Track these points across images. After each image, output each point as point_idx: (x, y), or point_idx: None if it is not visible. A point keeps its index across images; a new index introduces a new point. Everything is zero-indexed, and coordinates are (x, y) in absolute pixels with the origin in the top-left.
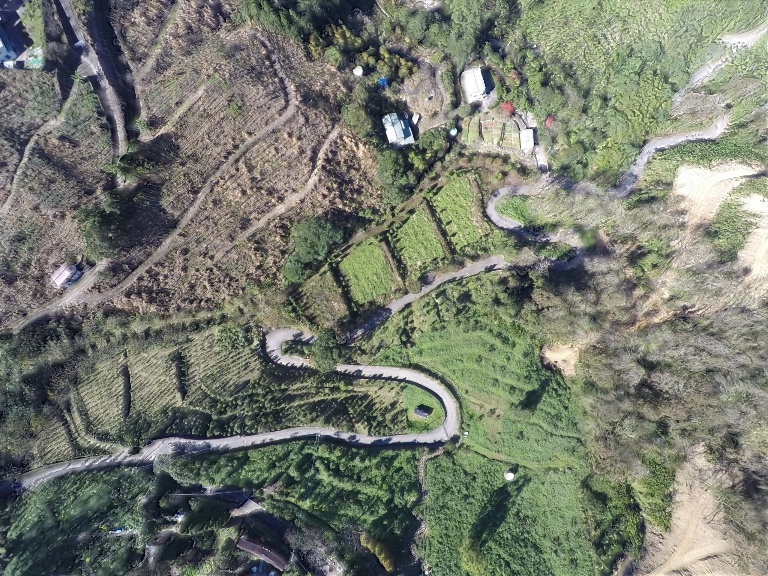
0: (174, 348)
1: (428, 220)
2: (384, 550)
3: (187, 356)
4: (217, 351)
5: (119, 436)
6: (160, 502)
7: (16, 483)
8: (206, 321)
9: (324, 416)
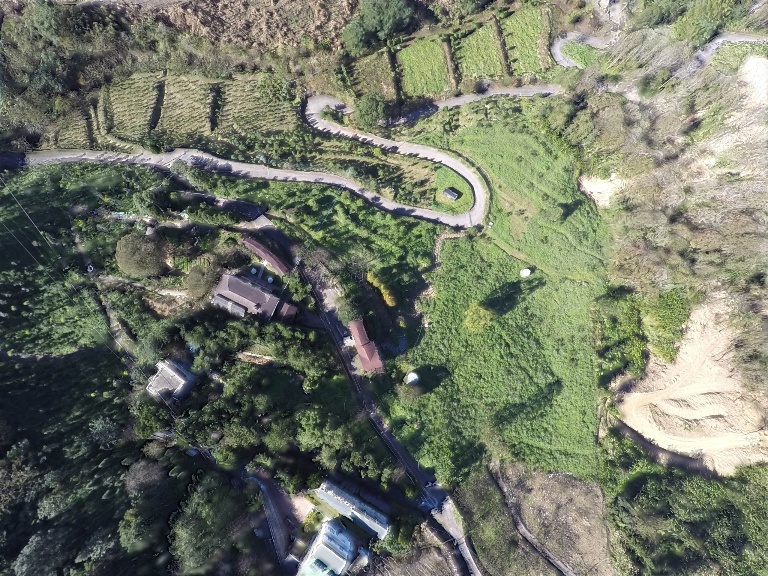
0: (215, 80)
1: (493, 37)
2: (389, 290)
3: (226, 94)
4: (257, 97)
5: (141, 141)
6: (172, 194)
7: (24, 161)
8: (253, 67)
9: (354, 167)
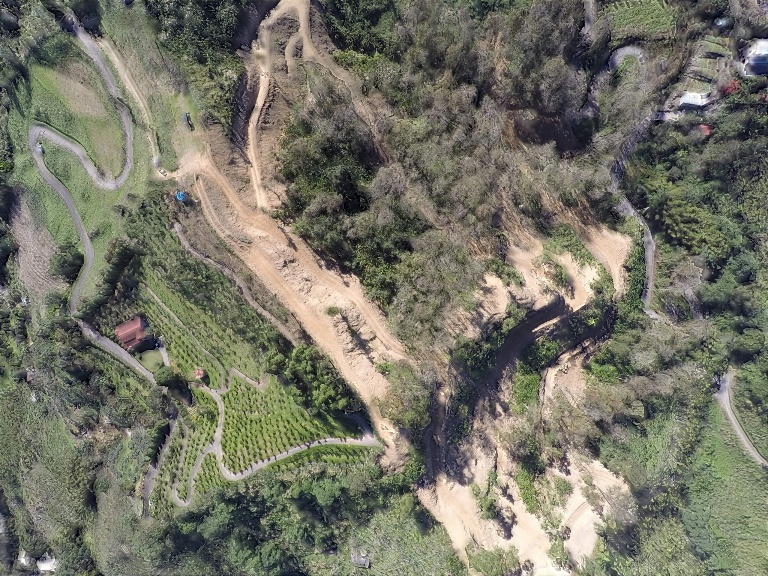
0: None
1: None
2: None
3: None
4: None
5: None
6: None
7: None
8: None
9: None
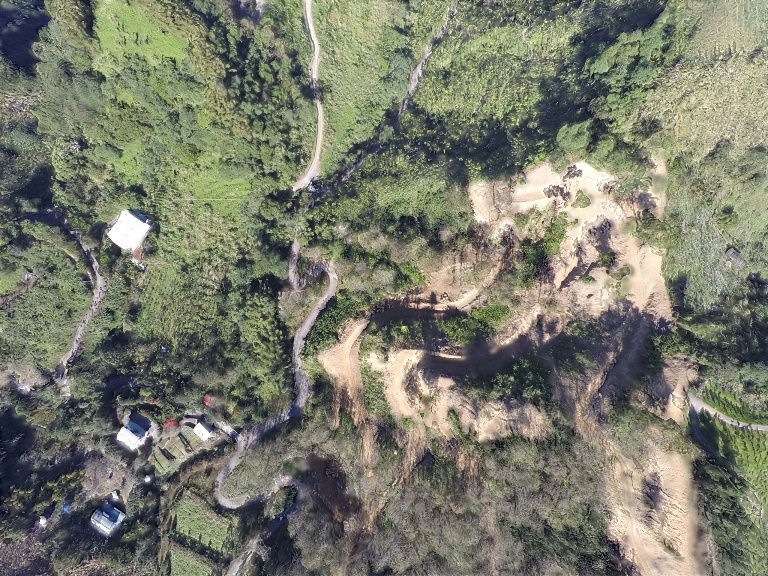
0: None
1: (183, 551)
2: None
3: None
4: None
5: None
6: None
7: None
8: None
9: None
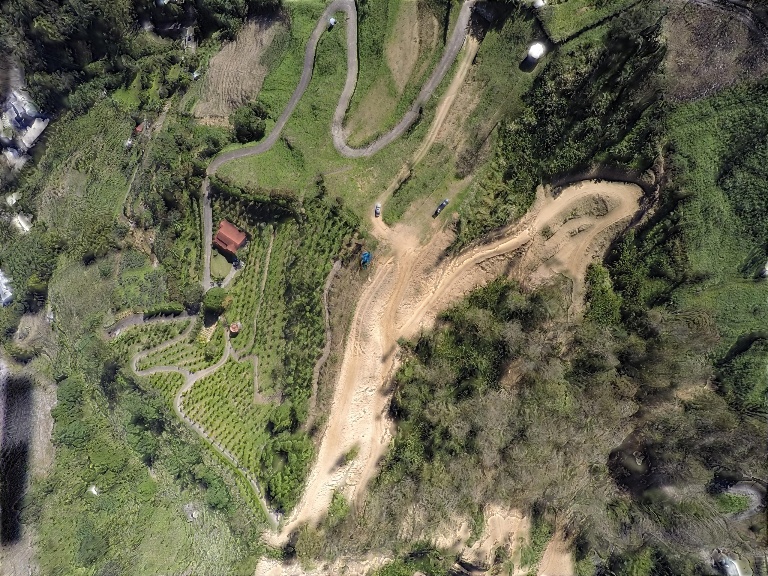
0: None
1: None
2: None
3: None
4: None
5: None
6: None
7: None
8: None
9: None
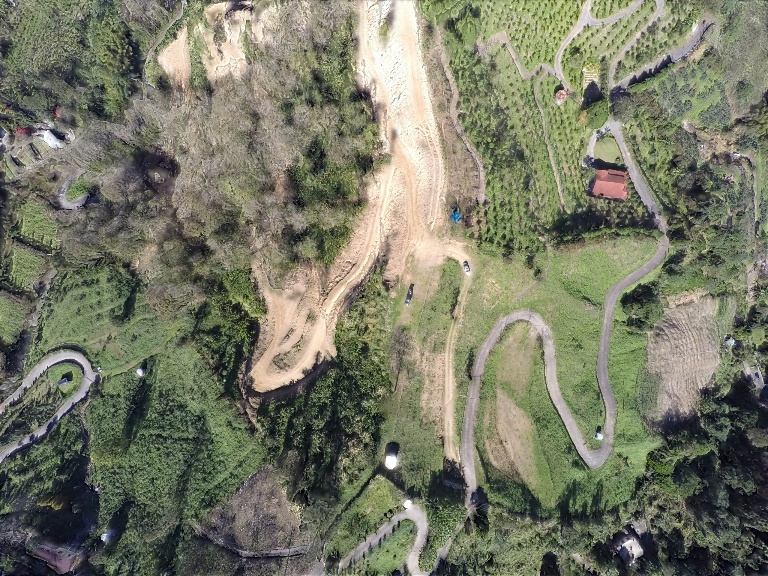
0: None
1: (24, 249)
2: (57, 497)
3: None
4: None
5: None
6: None
7: None
8: None
9: None
